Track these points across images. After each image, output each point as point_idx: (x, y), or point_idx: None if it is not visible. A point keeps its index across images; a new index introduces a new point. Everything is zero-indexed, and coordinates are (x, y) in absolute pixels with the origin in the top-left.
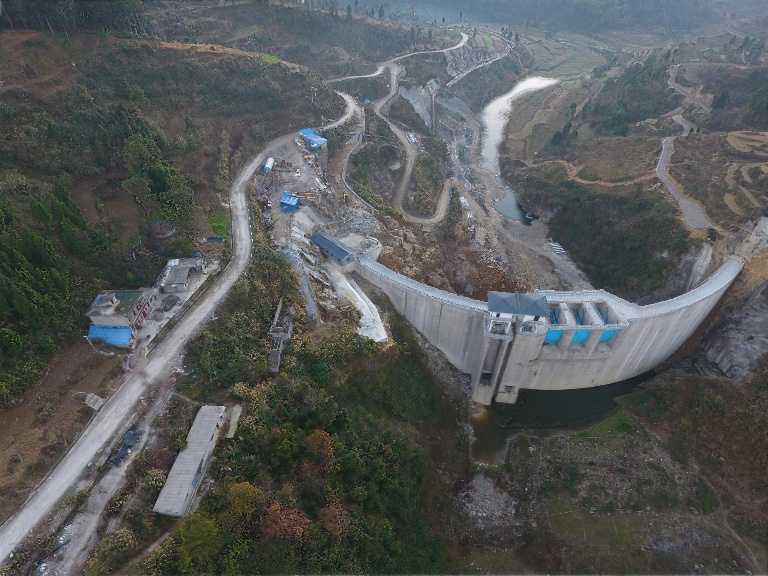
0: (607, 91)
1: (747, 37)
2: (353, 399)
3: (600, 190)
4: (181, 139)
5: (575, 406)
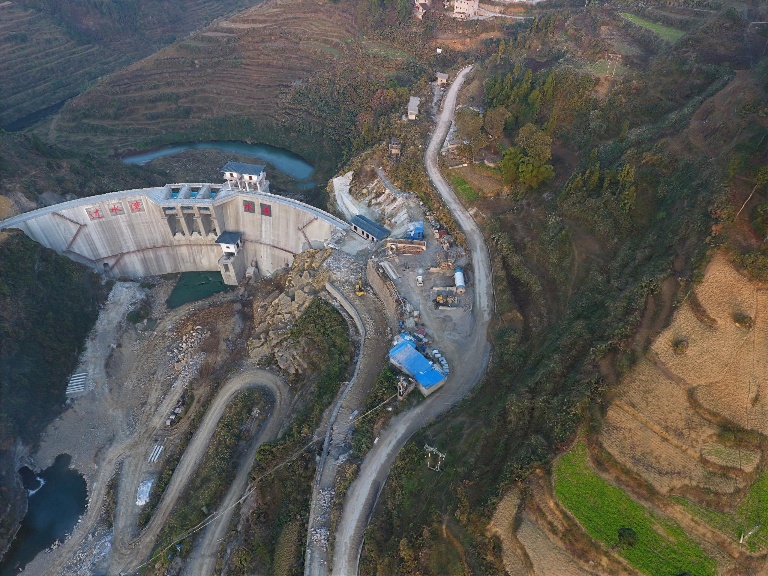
0: None
1: None
2: None
3: None
4: (554, 218)
5: None
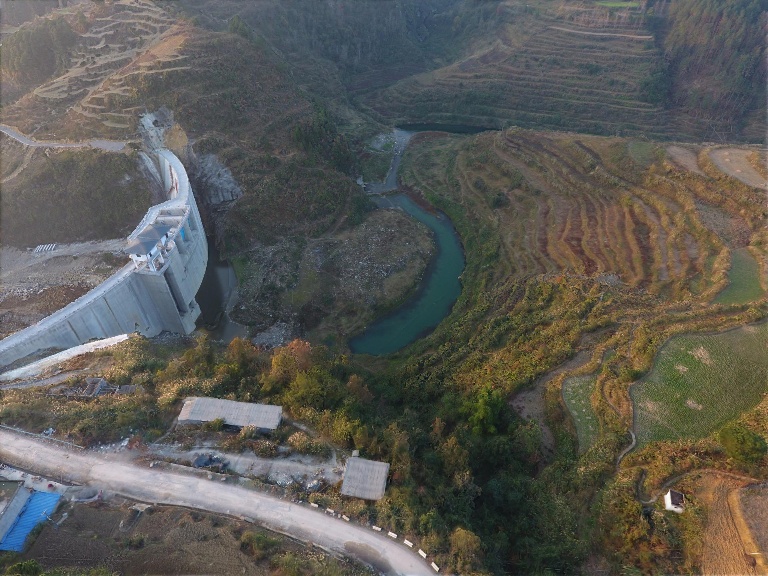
0: None
1: None
2: None
3: (12, 185)
4: None
5: (213, 288)
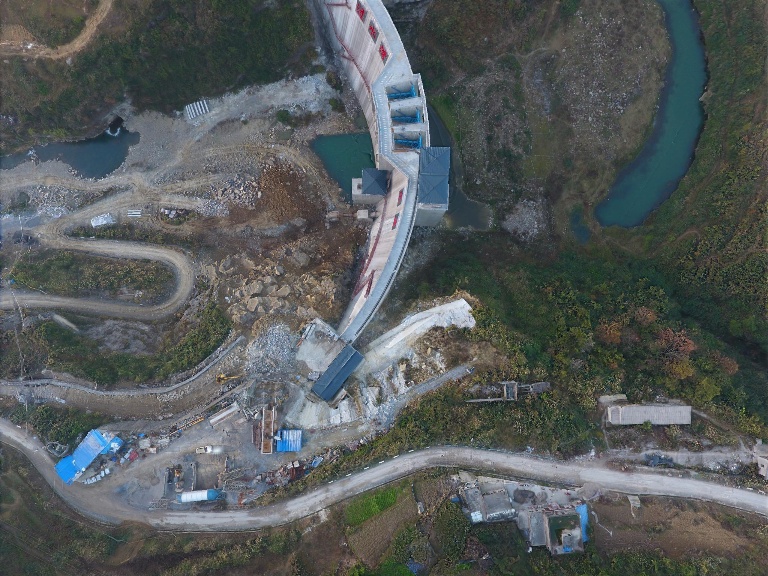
0: None
1: None
2: (516, 322)
3: (118, 27)
4: None
5: None
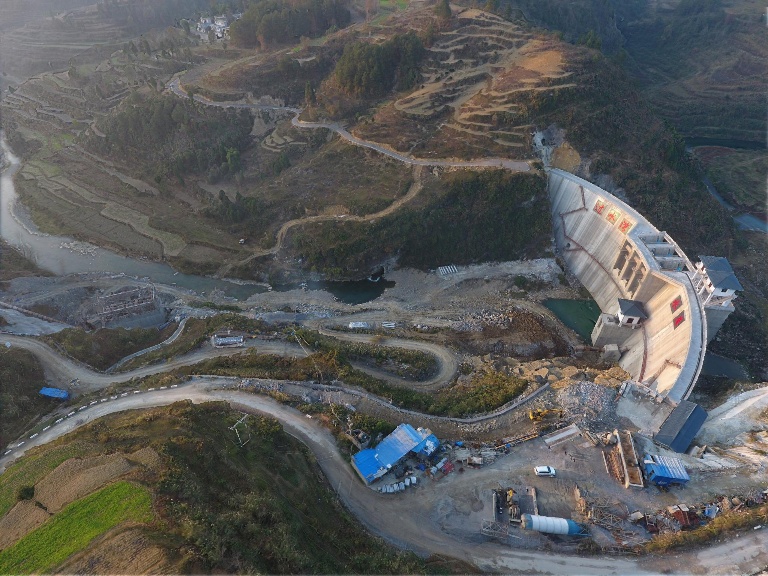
0: (126, 148)
1: (145, 41)
2: None
3: (417, 205)
4: None
5: None
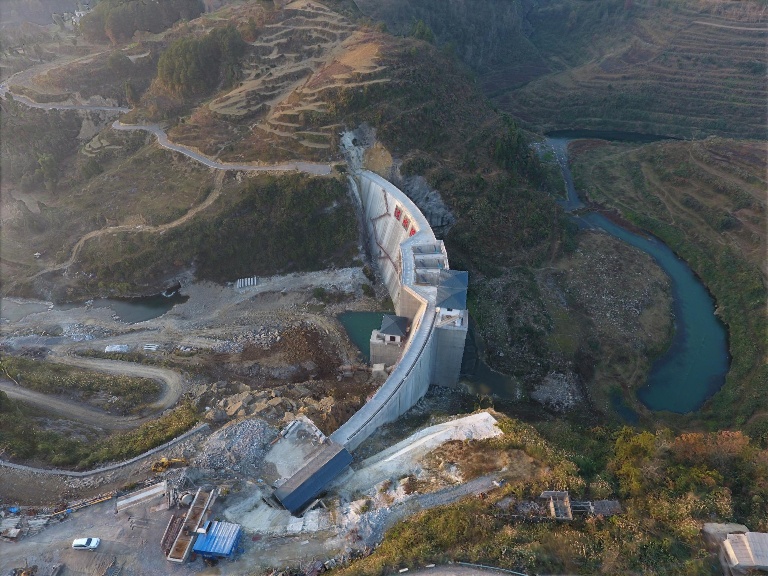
0: None
1: None
2: None
3: (211, 214)
4: None
5: None
